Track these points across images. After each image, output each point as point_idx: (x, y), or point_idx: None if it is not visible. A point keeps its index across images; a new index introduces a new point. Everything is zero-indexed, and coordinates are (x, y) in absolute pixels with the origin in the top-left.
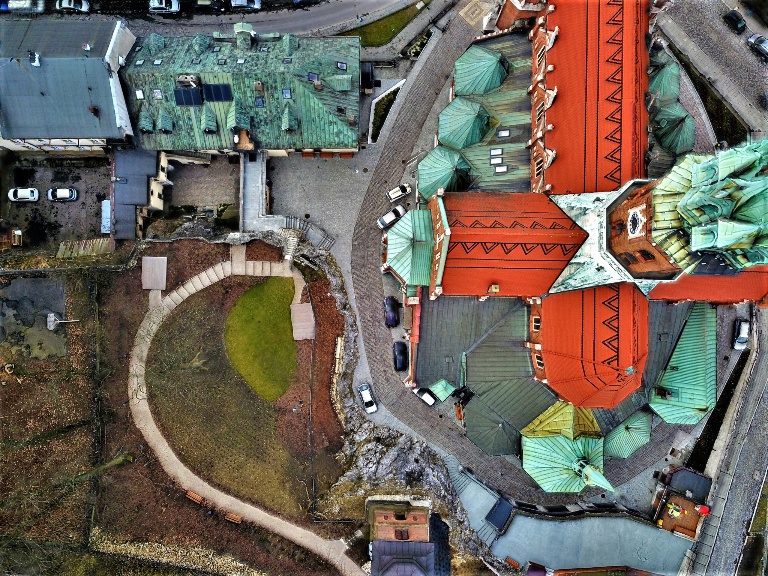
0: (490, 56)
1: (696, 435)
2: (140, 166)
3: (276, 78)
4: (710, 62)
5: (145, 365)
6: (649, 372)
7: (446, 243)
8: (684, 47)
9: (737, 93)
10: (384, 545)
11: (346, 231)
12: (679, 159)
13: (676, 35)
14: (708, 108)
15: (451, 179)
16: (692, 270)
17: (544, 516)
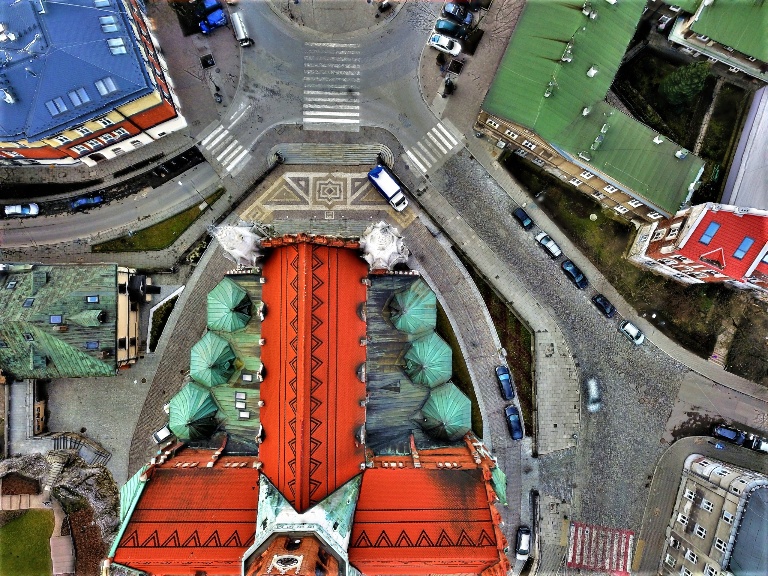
0: (231, 300)
1: None
2: None
3: (12, 325)
4: (497, 260)
5: None
6: None
7: None
8: (472, 245)
9: (524, 292)
10: None
11: (123, 445)
12: (432, 394)
13: (464, 232)
14: (492, 311)
15: (190, 429)
16: None
17: None
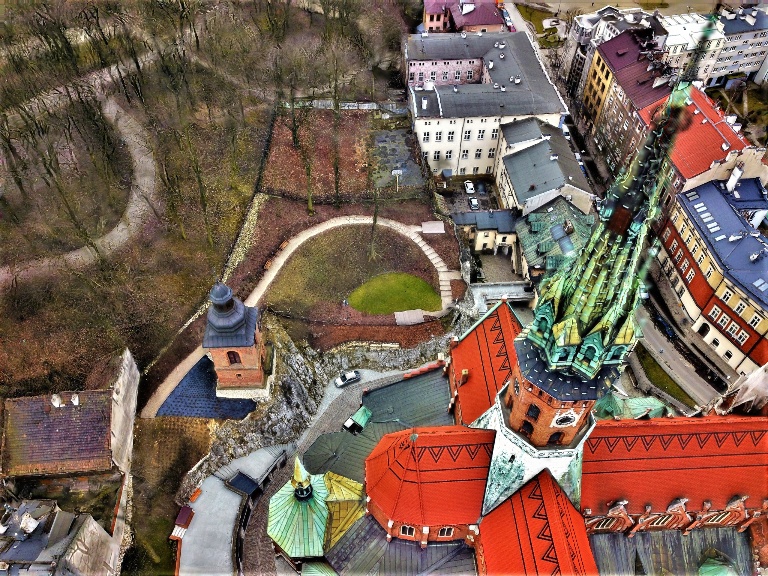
0: None
1: None
2: (503, 224)
3: None
4: None
5: (371, 223)
6: None
7: (495, 307)
8: None
9: None
10: (255, 312)
11: None
12: None
13: None
14: None
15: None
16: (518, 340)
17: (238, 524)
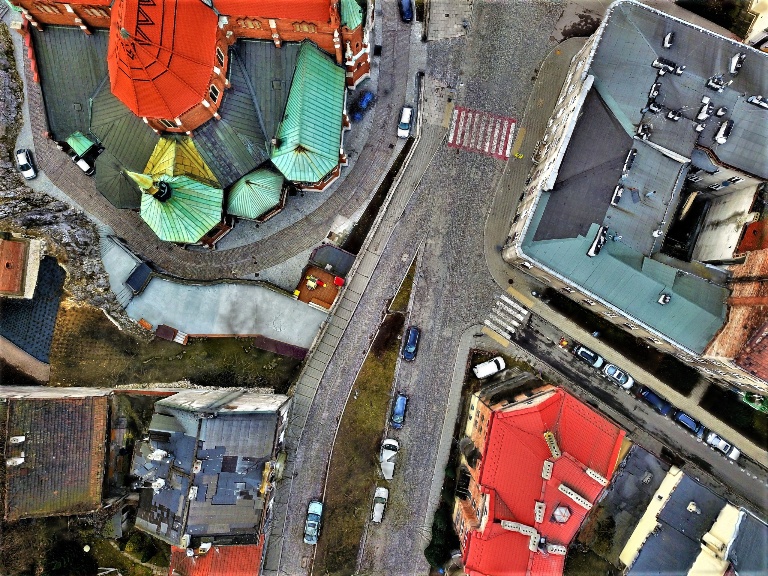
0: None
1: (354, 220)
2: None
3: None
4: None
5: None
6: (268, 124)
7: None
8: None
9: None
10: None
11: None
12: None
13: None
14: None
15: None
16: None
17: (180, 280)
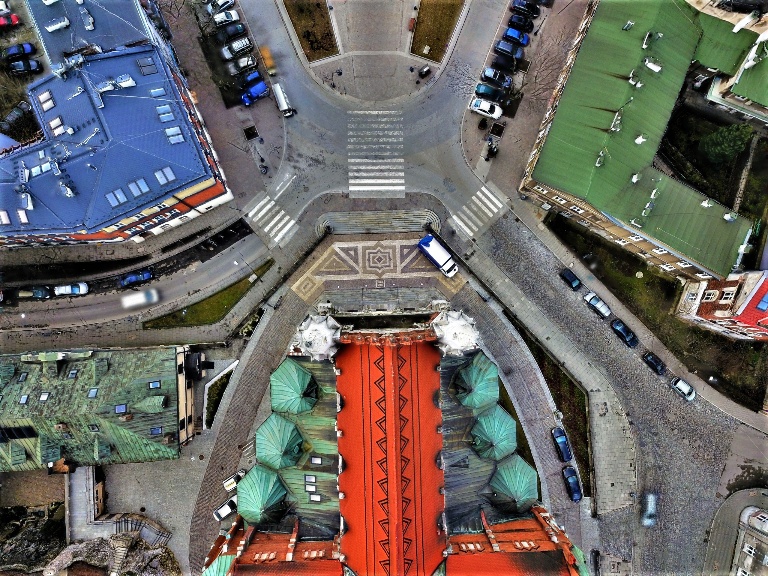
0: (297, 384)
1: None
2: None
3: (78, 418)
4: (548, 321)
5: None
6: None
7: None
8: (521, 307)
9: (576, 352)
10: None
11: (183, 523)
12: (499, 467)
13: (513, 295)
14: (545, 373)
15: (262, 516)
16: None
17: None
